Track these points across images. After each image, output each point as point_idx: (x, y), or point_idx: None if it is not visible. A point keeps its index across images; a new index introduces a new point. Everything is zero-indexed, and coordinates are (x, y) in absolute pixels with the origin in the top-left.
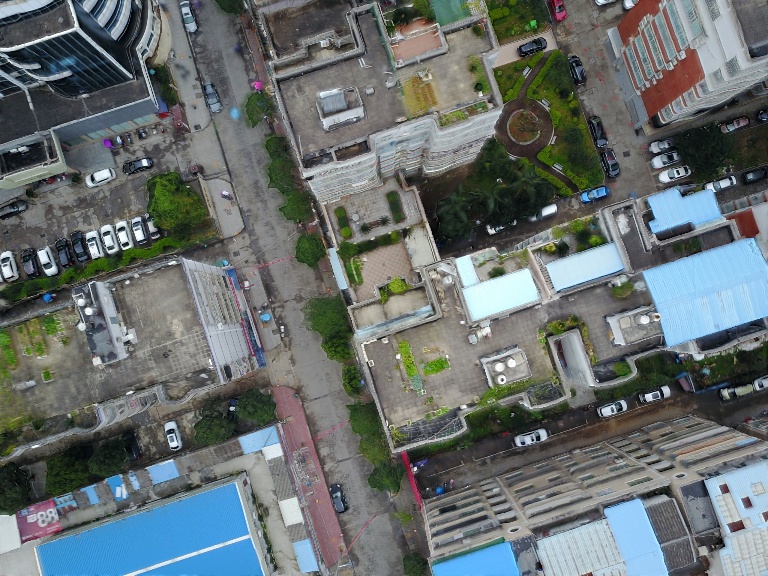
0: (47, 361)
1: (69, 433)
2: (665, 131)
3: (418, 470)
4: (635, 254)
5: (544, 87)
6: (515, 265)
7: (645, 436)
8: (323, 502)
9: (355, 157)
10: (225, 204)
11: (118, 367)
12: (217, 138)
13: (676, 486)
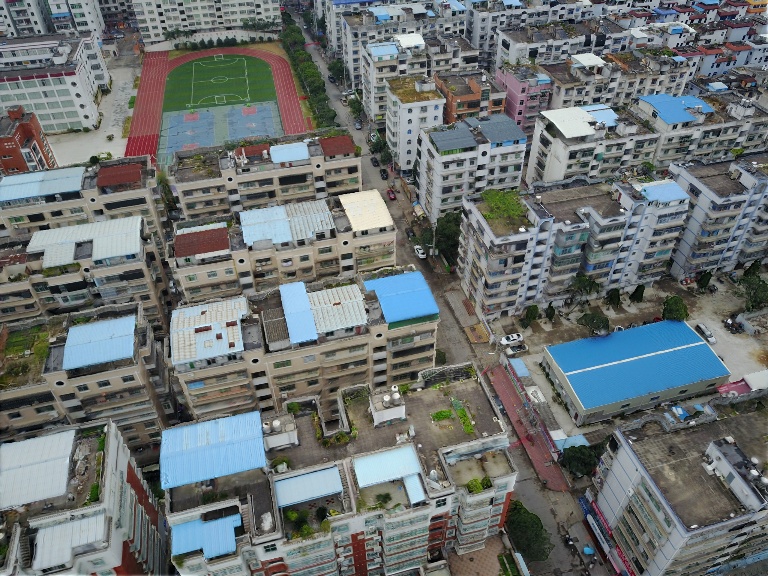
0: None
1: None
2: None
3: None
4: (262, 494)
5: None
6: None
7: None
8: (510, 404)
9: None
10: None
11: None
12: None
13: None
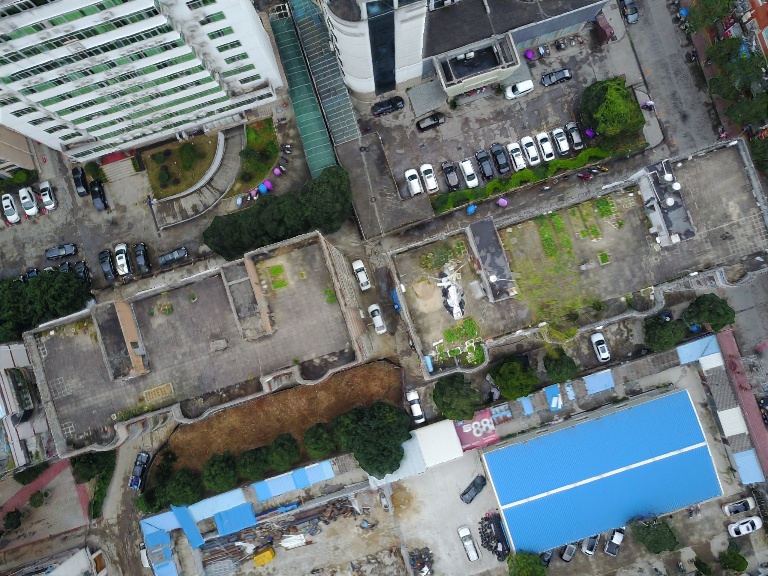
0: (601, 244)
1: None
2: None
3: None
4: None
5: None
6: None
7: None
8: (753, 415)
9: None
10: (644, 115)
11: (674, 249)
12: (632, 49)
13: None
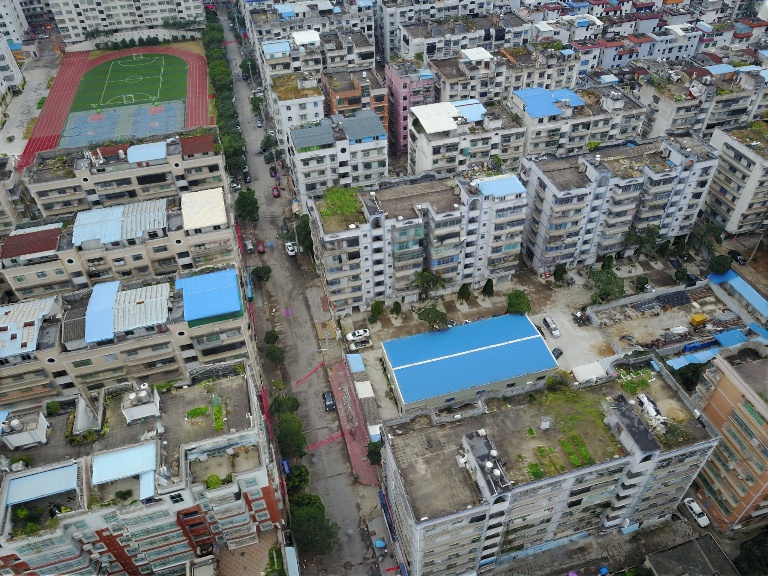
0: (534, 444)
1: (506, 393)
2: None
3: None
4: None
5: None
6: (105, 501)
7: None
8: (342, 400)
9: None
10: None
11: None
12: None
13: None
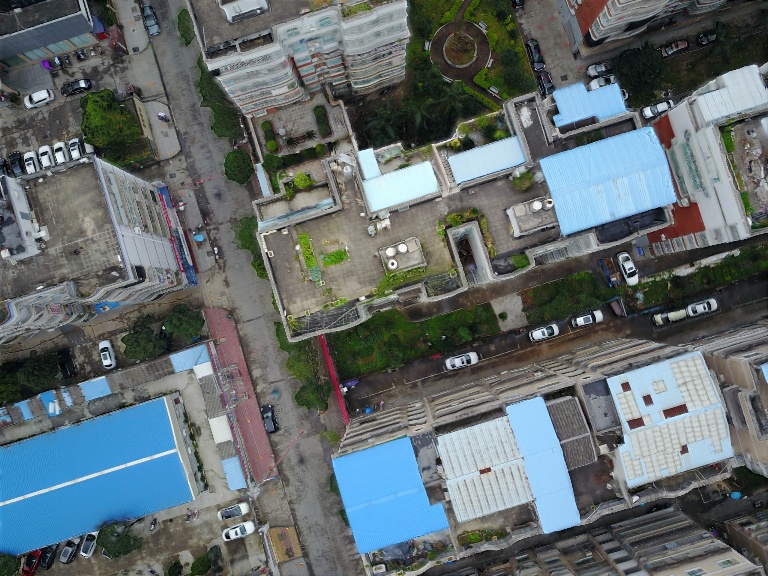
0: None
1: None
2: (602, 53)
3: (349, 392)
4: (537, 147)
5: (482, 10)
6: None
7: (571, 356)
8: (255, 422)
9: (257, 48)
10: (162, 126)
11: (30, 263)
12: (155, 61)
13: (579, 385)
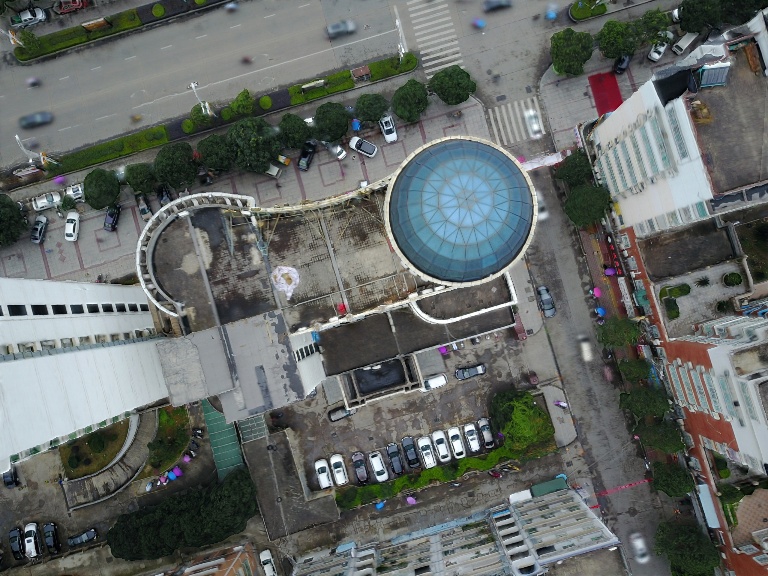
0: None
1: None
2: None
3: None
4: None
5: None
6: None
7: None
8: None
9: None
10: (558, 412)
11: None
12: (548, 343)
13: None
